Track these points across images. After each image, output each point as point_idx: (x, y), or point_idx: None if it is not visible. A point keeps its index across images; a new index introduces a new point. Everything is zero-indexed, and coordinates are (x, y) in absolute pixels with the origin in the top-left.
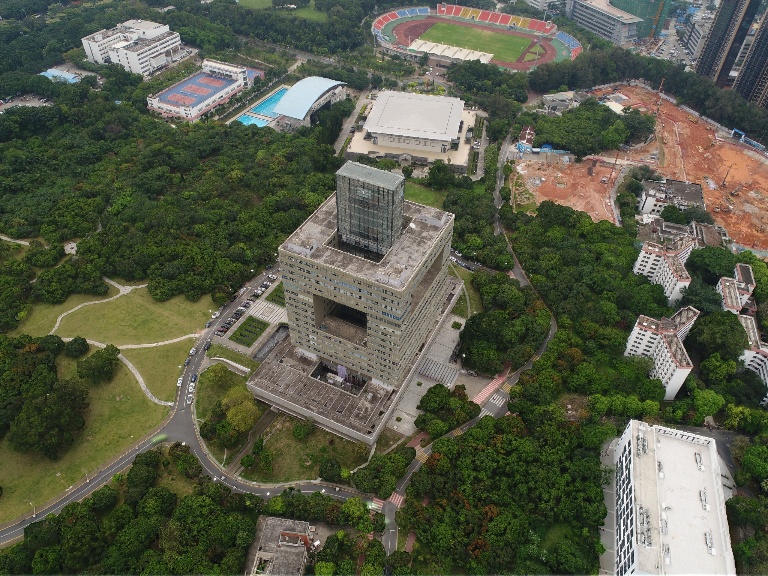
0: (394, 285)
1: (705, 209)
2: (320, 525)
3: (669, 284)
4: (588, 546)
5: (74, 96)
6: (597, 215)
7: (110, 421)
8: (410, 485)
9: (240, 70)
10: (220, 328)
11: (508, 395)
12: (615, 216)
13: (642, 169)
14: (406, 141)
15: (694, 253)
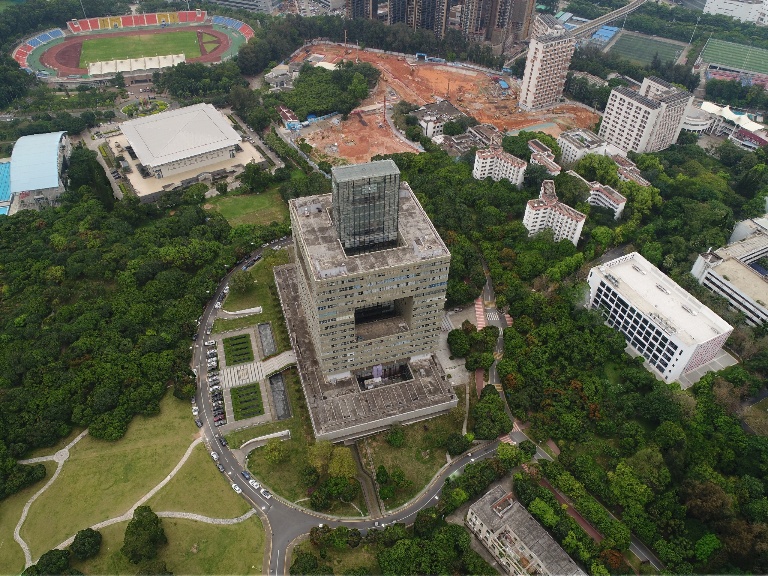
0: (438, 254)
1: (467, 116)
2: (492, 486)
3: (512, 174)
4: (633, 363)
5: None
6: None
7: (213, 574)
8: (516, 409)
9: None
10: (216, 418)
11: (495, 308)
12: (416, 148)
13: (402, 105)
14: (192, 161)
15: None
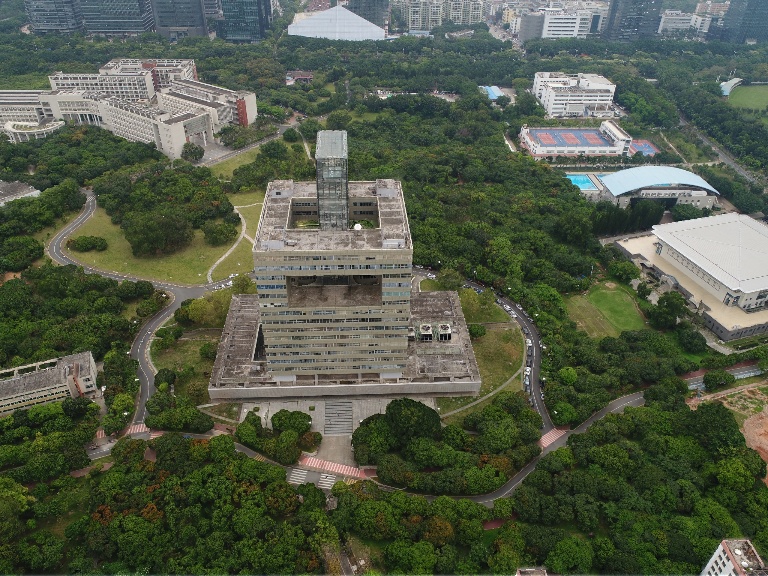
0: None
1: None
2: None
3: None
4: None
5: (470, 102)
6: None
7: (180, 263)
8: None
9: (624, 138)
10: None
11: None
12: None
13: None
14: (690, 266)
15: None
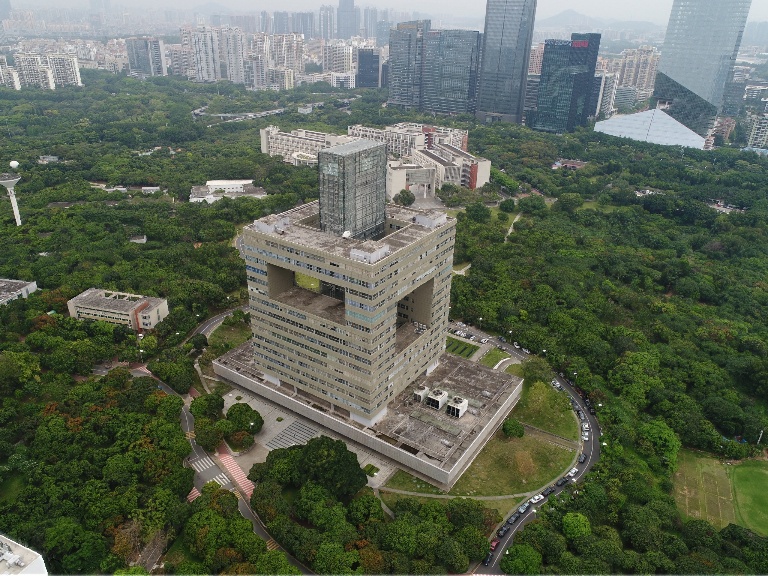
0: None
1: None
2: None
3: None
4: None
5: (748, 217)
6: None
7: None
8: None
9: None
10: None
11: None
12: None
13: None
14: None
15: None
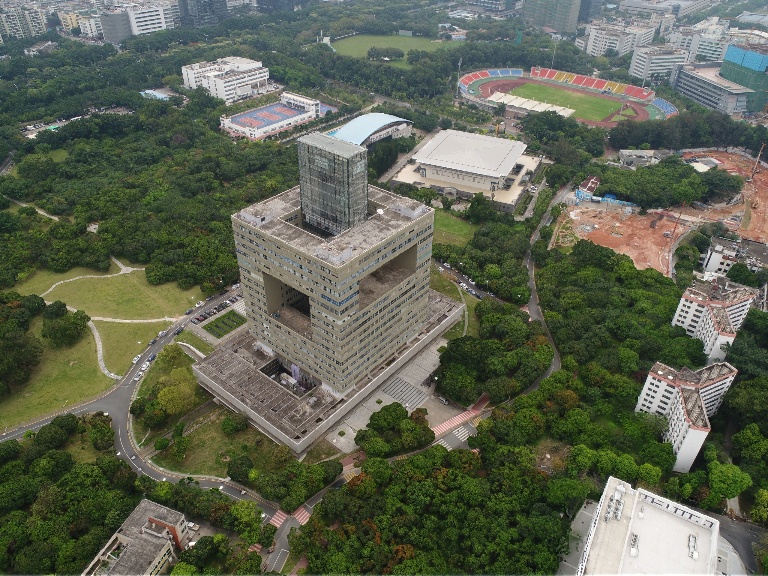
0: (333, 262)
1: None
2: (206, 525)
3: (709, 339)
4: None
5: (155, 109)
6: (649, 266)
7: (54, 383)
8: (320, 502)
9: (313, 102)
10: (198, 316)
11: None
12: (670, 269)
13: (714, 225)
14: (455, 175)
15: (756, 314)
